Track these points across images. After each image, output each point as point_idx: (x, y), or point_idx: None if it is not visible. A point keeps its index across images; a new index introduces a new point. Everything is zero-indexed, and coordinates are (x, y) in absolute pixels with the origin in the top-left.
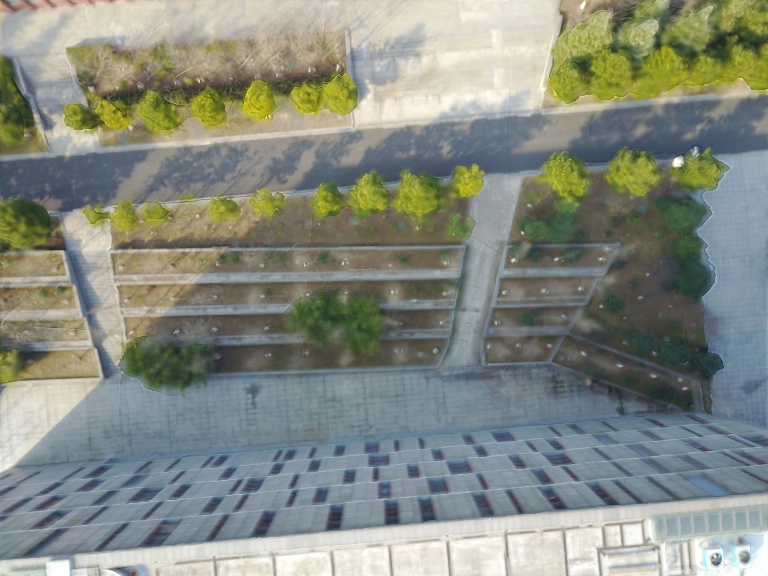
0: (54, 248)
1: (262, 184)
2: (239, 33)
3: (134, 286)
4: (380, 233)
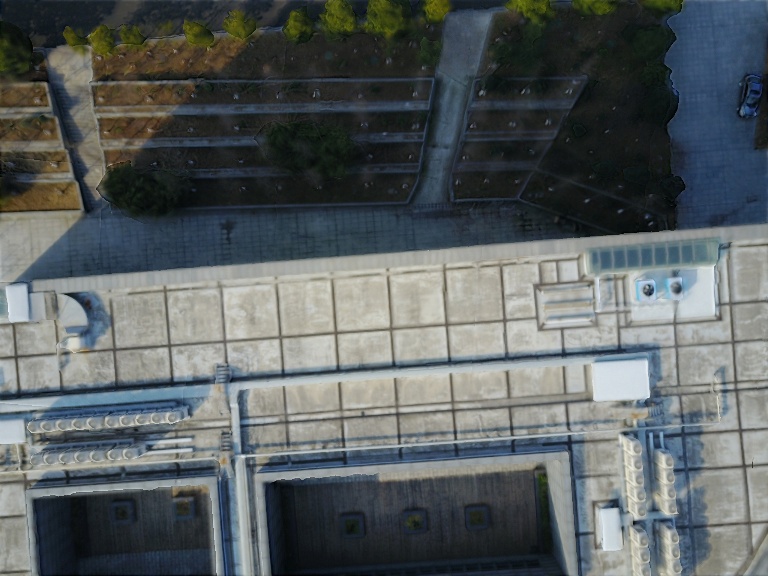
0: (37, 79)
1: None
2: None
3: (113, 118)
4: (351, 68)
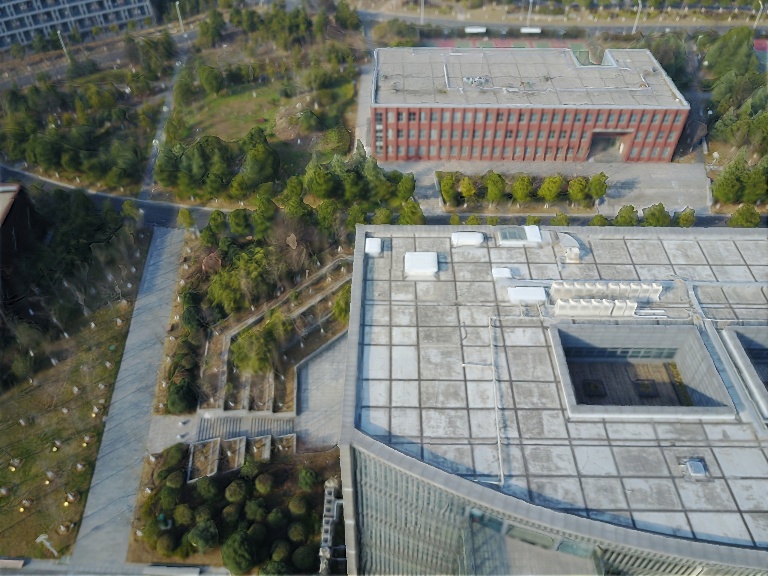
0: None
1: None
2: (529, 174)
3: None
4: None
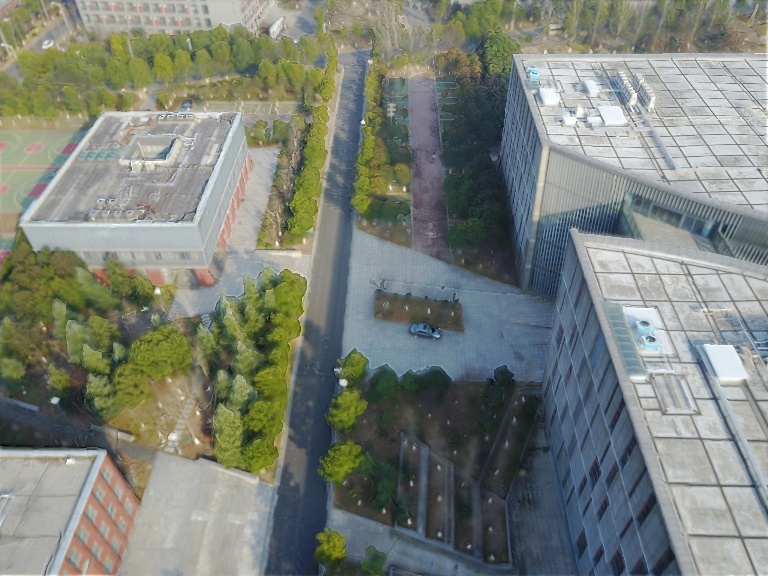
0: None
1: None
2: None
3: None
4: None
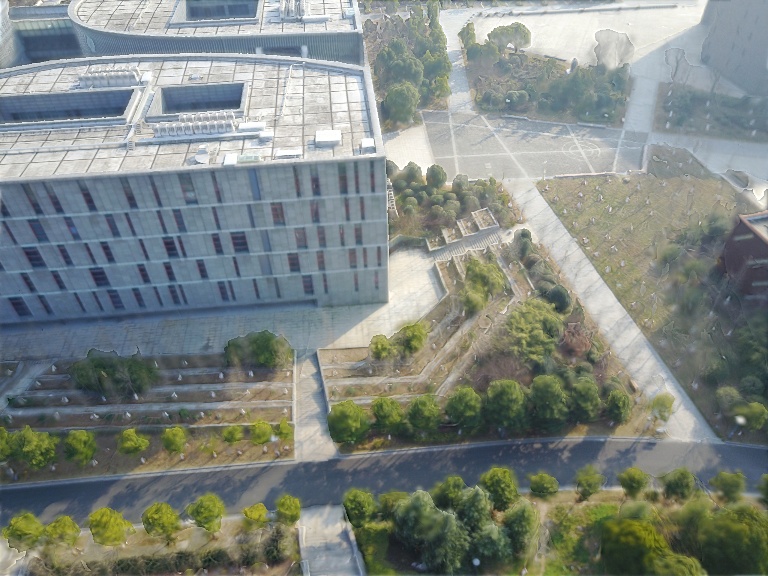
0: None
1: (151, 484)
2: None
3: None
4: None
